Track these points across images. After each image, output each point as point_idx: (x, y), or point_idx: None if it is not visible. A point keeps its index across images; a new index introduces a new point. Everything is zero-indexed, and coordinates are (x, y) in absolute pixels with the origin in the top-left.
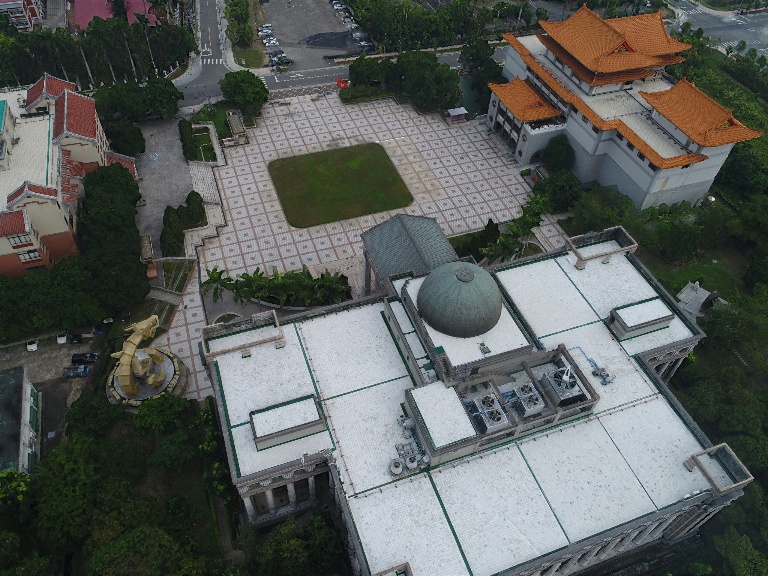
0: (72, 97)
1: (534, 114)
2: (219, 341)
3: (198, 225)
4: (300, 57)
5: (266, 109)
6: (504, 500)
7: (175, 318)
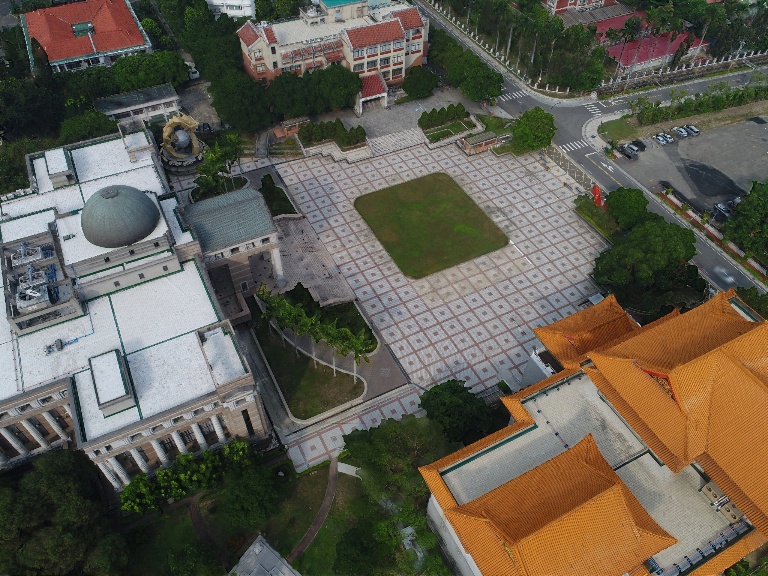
0: (395, 24)
1: (558, 345)
2: (142, 135)
3: (342, 147)
4: (650, 164)
5: (531, 157)
6: None
7: (245, 159)
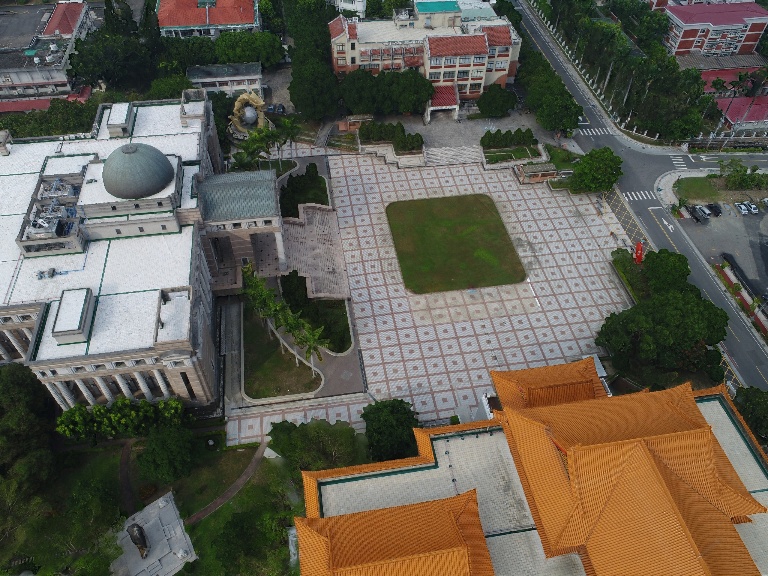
0: (480, 39)
1: (509, 393)
2: (203, 105)
3: (398, 151)
4: (719, 232)
5: (587, 198)
6: (8, 198)
7: (304, 144)
